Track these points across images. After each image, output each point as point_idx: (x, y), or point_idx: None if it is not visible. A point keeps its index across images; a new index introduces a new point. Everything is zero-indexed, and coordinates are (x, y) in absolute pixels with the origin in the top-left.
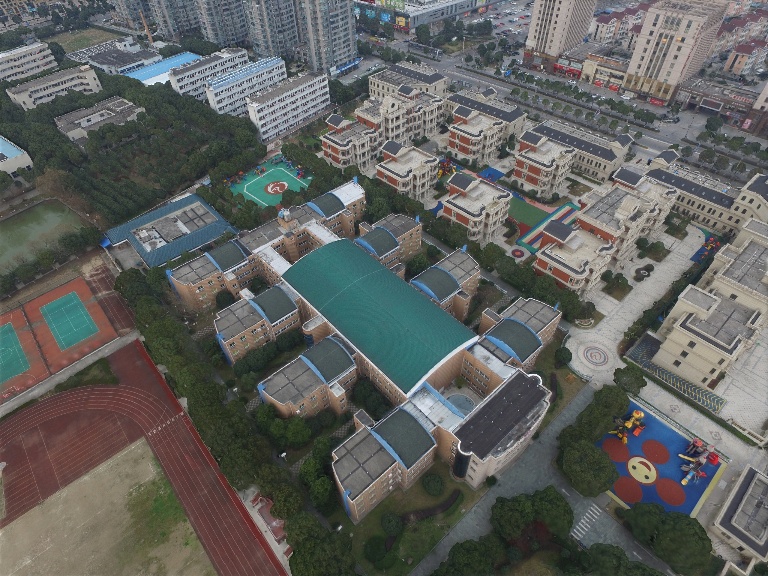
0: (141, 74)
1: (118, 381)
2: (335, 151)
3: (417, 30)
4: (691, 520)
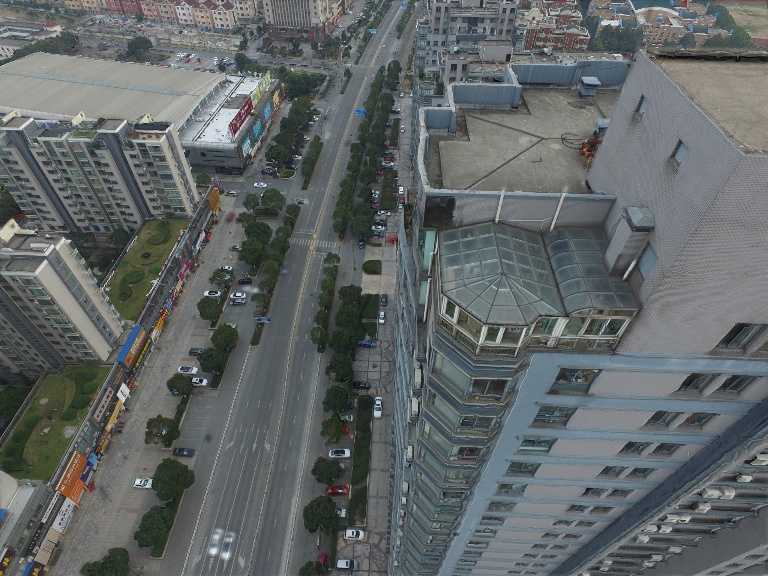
0: None
1: (759, 47)
2: None
3: (301, 83)
4: None
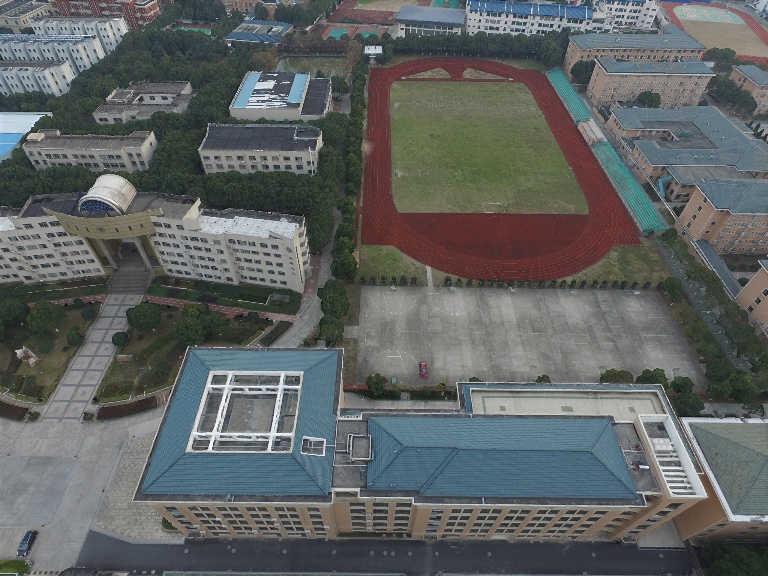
0: (1, 142)
1: None
2: (154, 7)
3: None
4: None
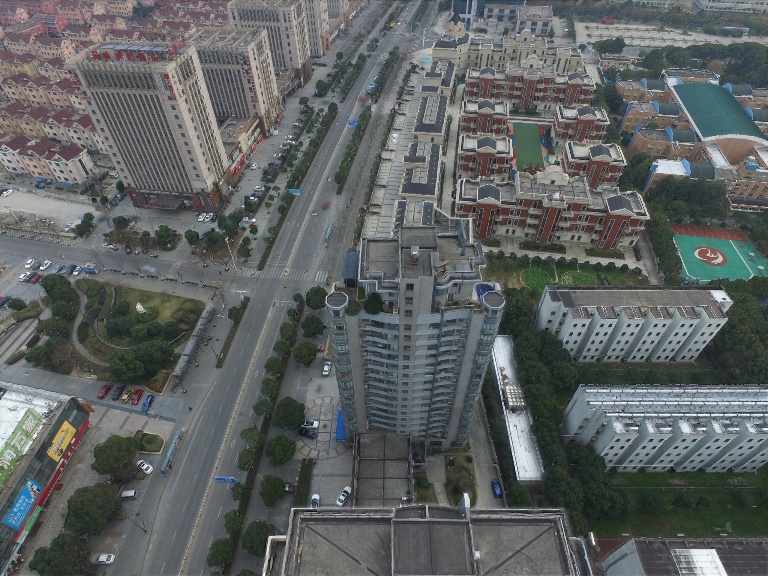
0: None
1: None
2: None
3: (132, 370)
4: (655, 50)
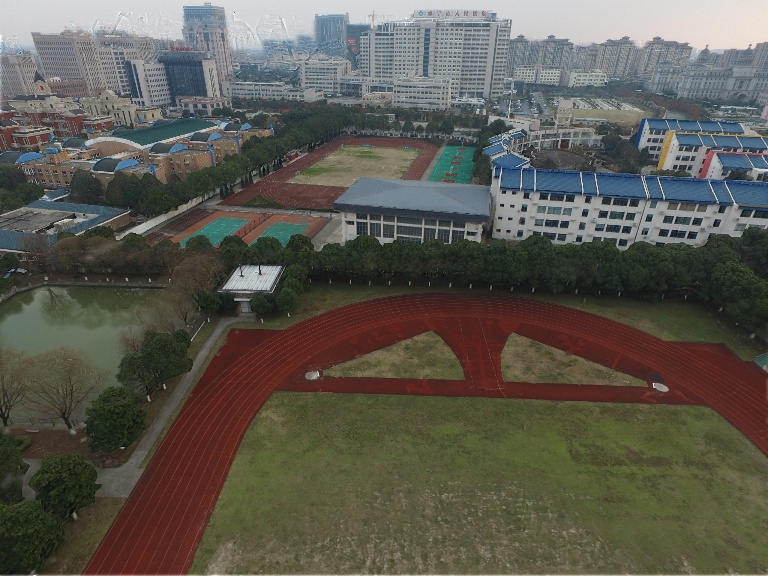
0: None
1: None
2: None
3: None
4: None
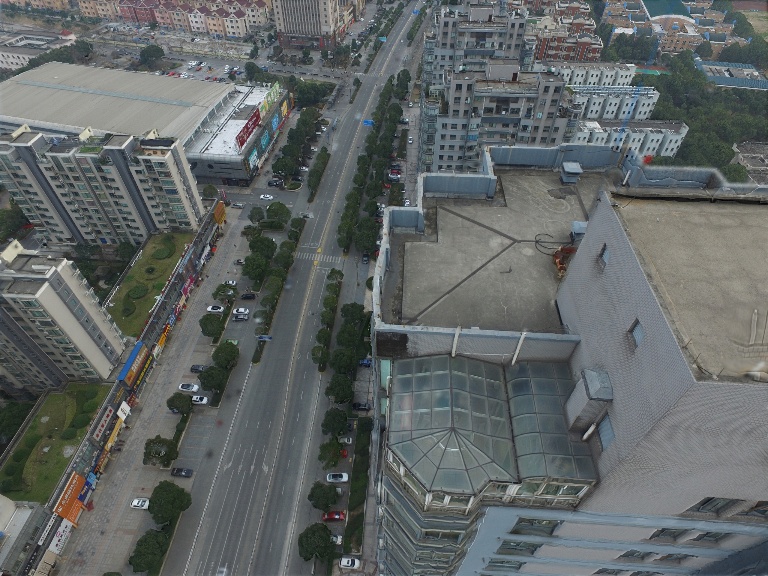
0: None
1: None
2: None
3: (310, 93)
4: None
